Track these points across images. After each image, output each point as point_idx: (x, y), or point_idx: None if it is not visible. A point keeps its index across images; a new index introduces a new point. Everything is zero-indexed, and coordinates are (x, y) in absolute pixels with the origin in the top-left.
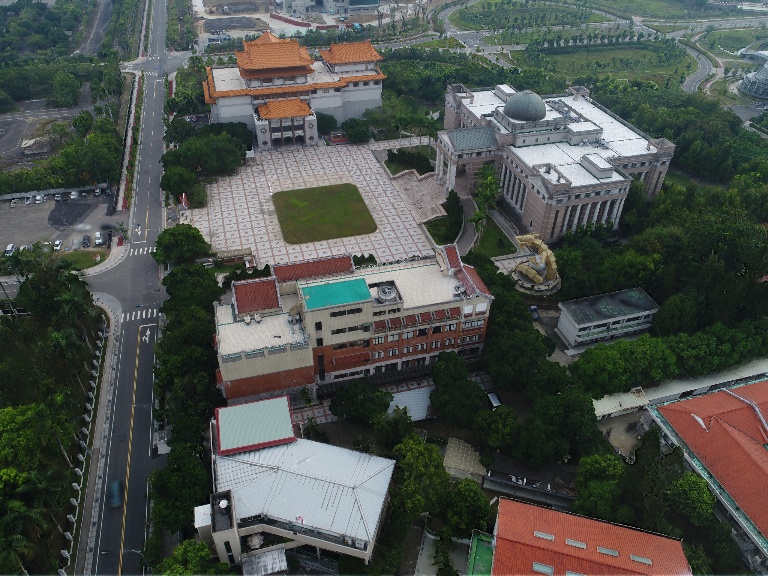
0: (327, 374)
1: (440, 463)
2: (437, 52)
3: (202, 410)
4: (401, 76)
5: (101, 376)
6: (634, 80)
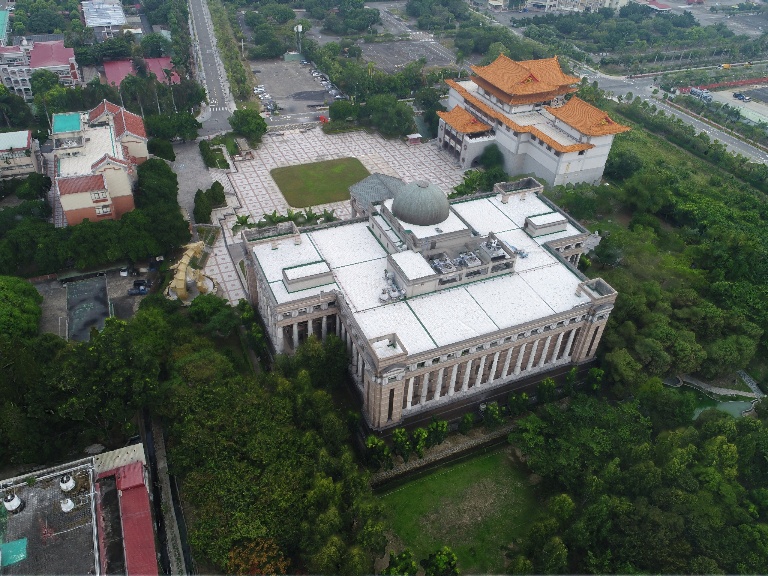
0: None
1: None
2: None
3: None
4: (643, 184)
5: None
6: None
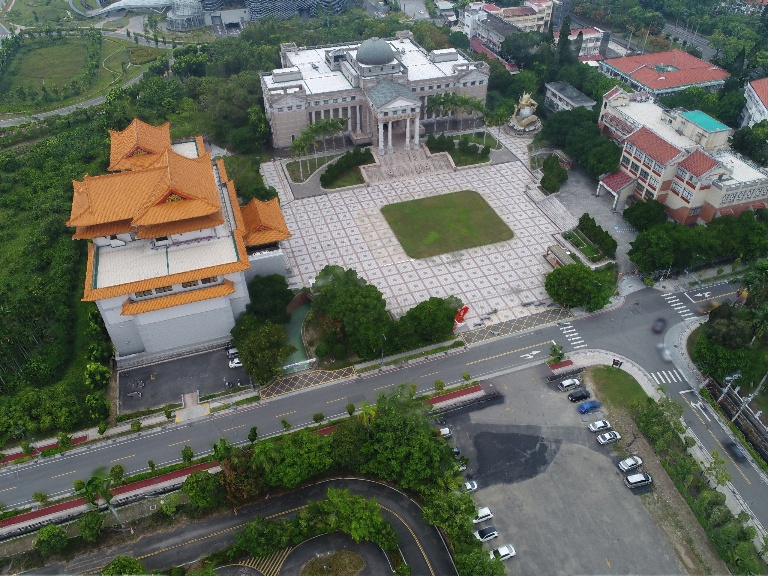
0: None
1: None
2: None
3: None
4: None
5: None
6: (178, 51)
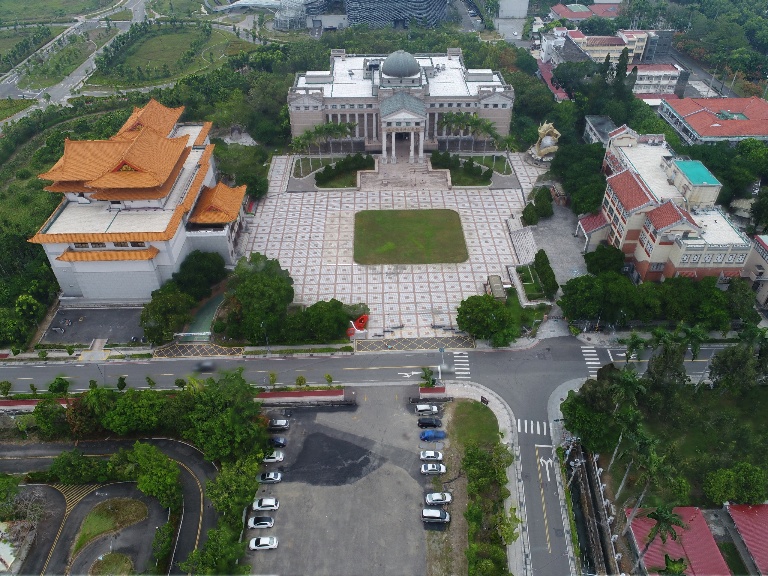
0: None
1: None
2: (54, 112)
3: None
4: None
5: None
6: (261, 47)
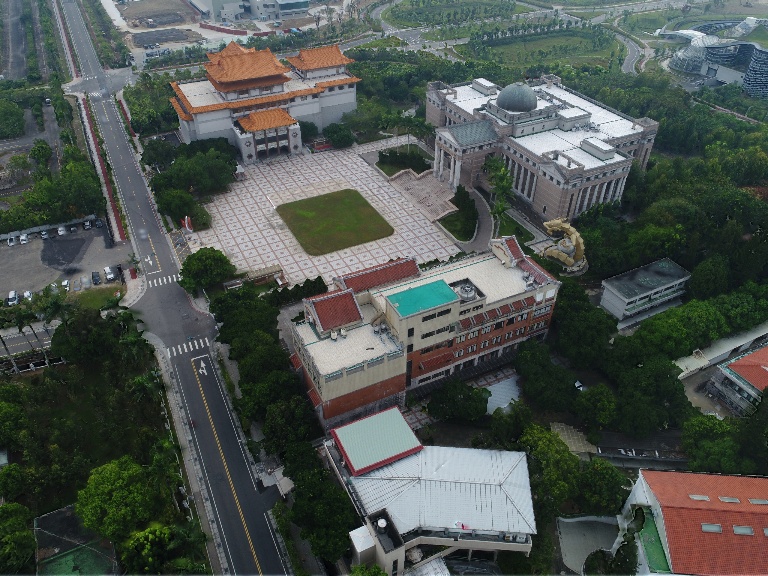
0: (413, 379)
1: (566, 447)
2: (386, 51)
3: (303, 434)
4: (367, 78)
5: (171, 417)
6: (582, 65)
